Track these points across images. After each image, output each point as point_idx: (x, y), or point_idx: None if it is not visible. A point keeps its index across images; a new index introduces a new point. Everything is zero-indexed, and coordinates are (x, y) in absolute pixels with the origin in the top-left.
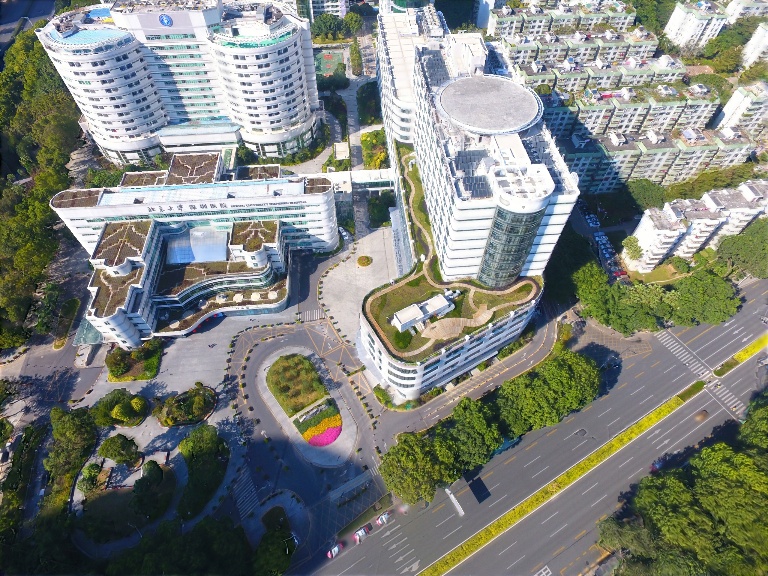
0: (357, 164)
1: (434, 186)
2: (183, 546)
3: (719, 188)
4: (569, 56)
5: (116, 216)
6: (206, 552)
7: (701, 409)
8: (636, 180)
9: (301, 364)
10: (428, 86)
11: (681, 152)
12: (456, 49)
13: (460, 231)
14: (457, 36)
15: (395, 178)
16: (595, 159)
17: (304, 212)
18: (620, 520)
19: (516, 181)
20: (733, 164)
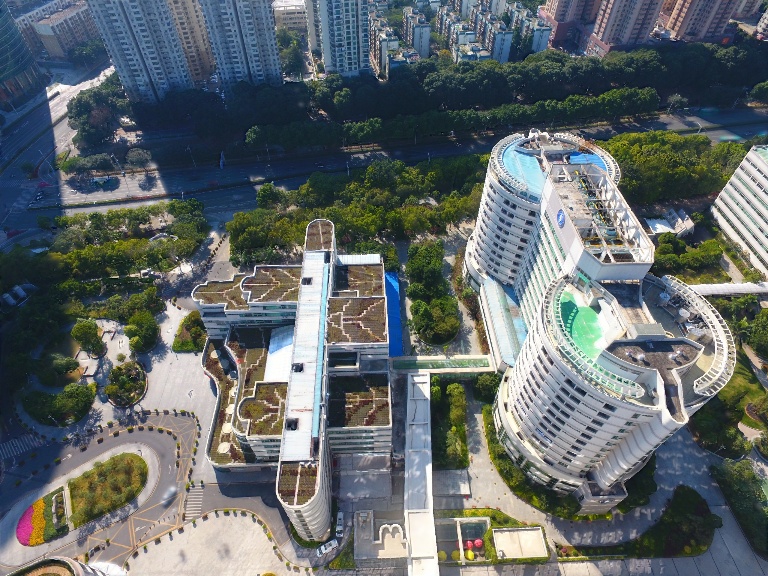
0: None
1: None
2: None
3: None
4: None
5: None
6: None
7: None
8: None
9: None
10: None
11: None
12: None
13: None
14: None
15: None
16: None
17: None
18: None
19: None
20: None
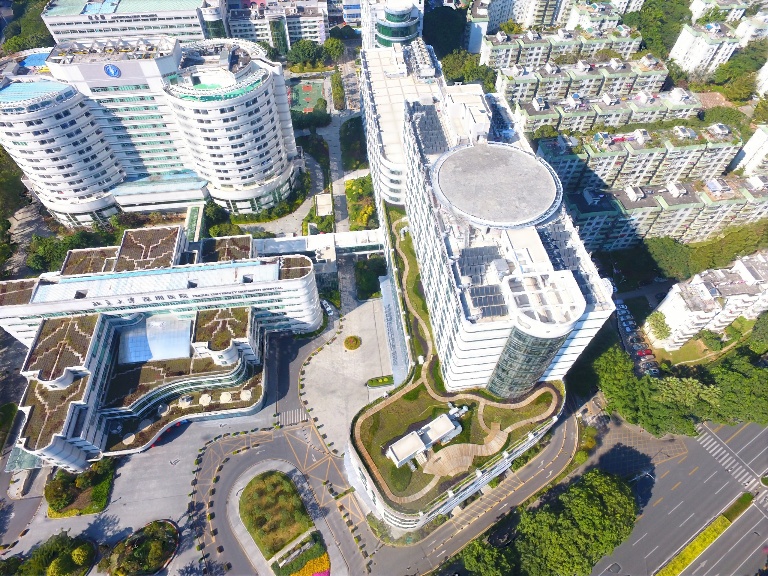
0: (342, 218)
1: (432, 275)
2: None
3: (750, 248)
4: (572, 88)
5: (55, 312)
6: None
7: (751, 531)
8: (656, 239)
9: (280, 485)
10: (422, 154)
11: (705, 206)
12: (454, 109)
13: (468, 350)
14: (453, 89)
15: (385, 244)
16: (611, 217)
17: (280, 297)
18: None
19: (535, 290)
20: (761, 216)
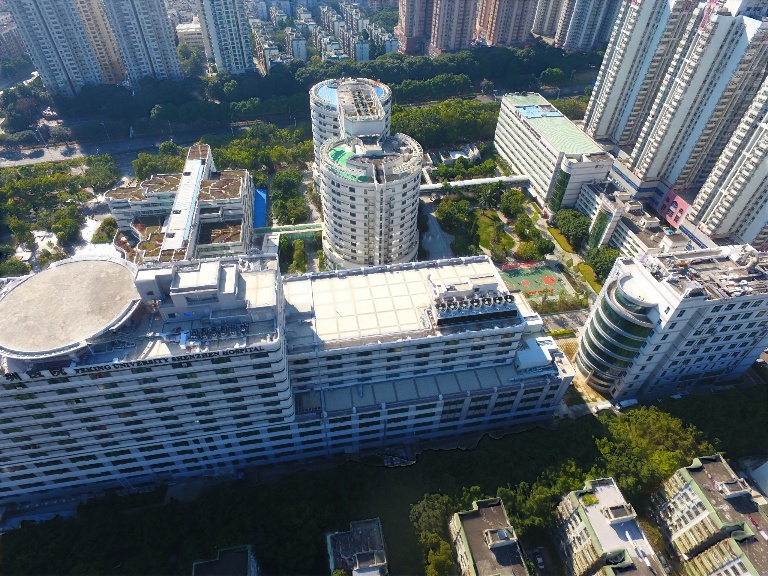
0: None
1: None
2: None
3: None
4: None
5: None
6: None
7: None
8: None
9: None
10: None
11: None
12: None
13: None
14: (269, 281)
15: None
16: None
17: None
18: None
19: None
20: None
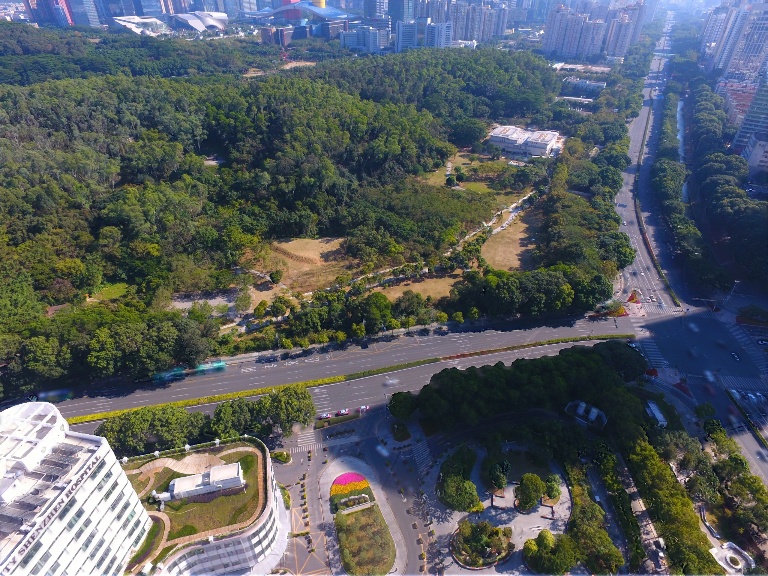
0: None
1: None
2: (452, 387)
3: None
4: None
5: None
6: (439, 386)
7: None
8: None
9: None
10: None
11: None
12: None
13: None
14: None
15: None
16: None
17: None
18: (180, 378)
19: None
20: None
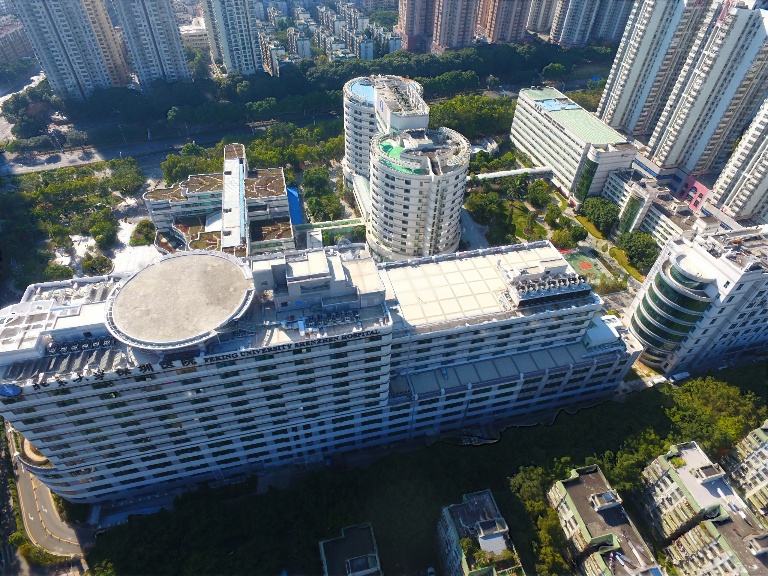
0: None
1: None
2: None
3: None
4: None
5: None
6: None
7: None
8: None
9: None
10: None
11: None
12: None
13: None
14: (371, 268)
15: None
16: None
17: None
18: None
19: None
20: None
